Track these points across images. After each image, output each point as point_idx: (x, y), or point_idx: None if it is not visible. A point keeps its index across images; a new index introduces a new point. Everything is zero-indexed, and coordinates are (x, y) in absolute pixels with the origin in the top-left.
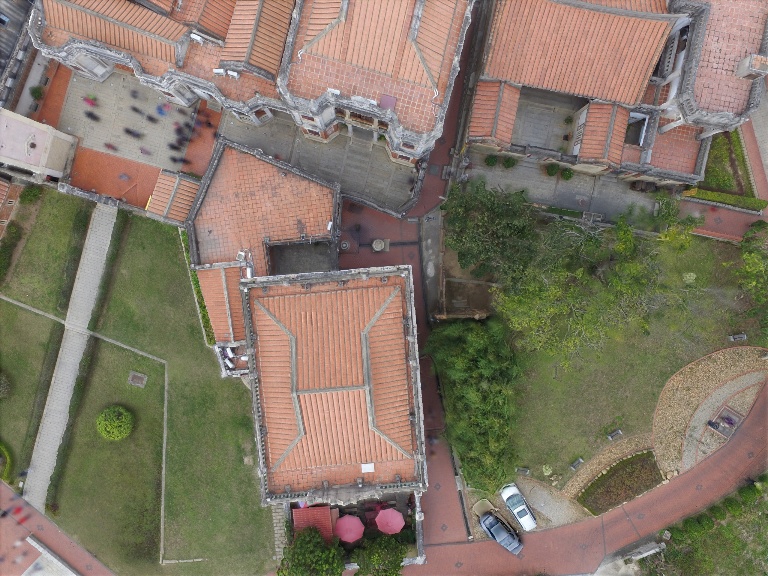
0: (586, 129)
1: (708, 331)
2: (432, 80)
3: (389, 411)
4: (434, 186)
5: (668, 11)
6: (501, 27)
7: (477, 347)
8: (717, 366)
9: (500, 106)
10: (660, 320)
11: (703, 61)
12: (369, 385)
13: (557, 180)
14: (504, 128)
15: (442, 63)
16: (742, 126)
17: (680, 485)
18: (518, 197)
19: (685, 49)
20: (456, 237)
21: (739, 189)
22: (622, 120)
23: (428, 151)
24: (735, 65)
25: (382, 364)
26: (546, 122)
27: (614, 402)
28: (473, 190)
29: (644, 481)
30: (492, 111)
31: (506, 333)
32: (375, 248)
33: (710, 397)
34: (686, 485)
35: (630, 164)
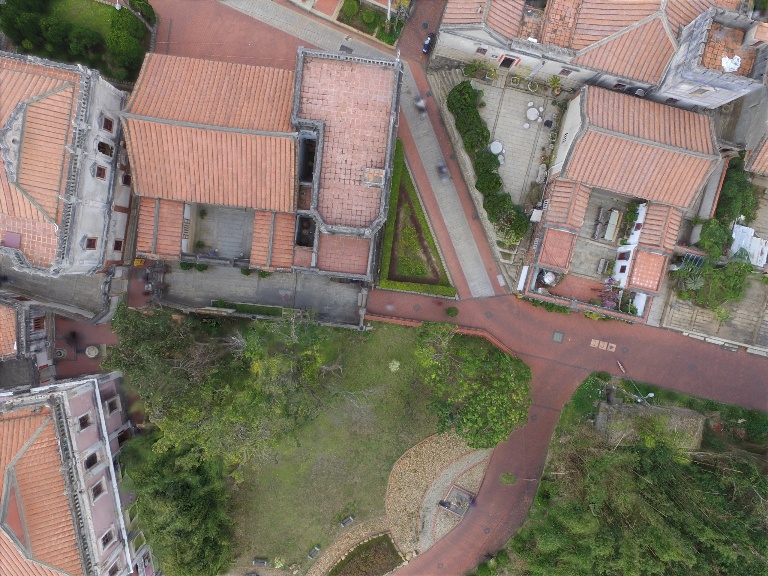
0: (254, 235)
1: (427, 413)
2: (47, 217)
3: (49, 539)
4: (142, 289)
5: (291, 126)
6: (135, 151)
7: (154, 461)
8: (440, 447)
9: (158, 222)
10: (379, 406)
11: (330, 173)
12: (2, 524)
13: (259, 277)
14: (168, 242)
15: (59, 198)
16: (430, 214)
17: (421, 565)
18: (159, 319)
19: (314, 161)
20: (105, 361)
21: (434, 275)
22: (287, 225)
23: (99, 268)
24: (362, 175)
25: (35, 494)
26: (240, 222)
27: (344, 489)
28: (176, 293)
29: (379, 565)
30: (152, 227)
31: (183, 445)
32: (89, 355)
33: (438, 477)
34: (427, 564)
35: (296, 268)
